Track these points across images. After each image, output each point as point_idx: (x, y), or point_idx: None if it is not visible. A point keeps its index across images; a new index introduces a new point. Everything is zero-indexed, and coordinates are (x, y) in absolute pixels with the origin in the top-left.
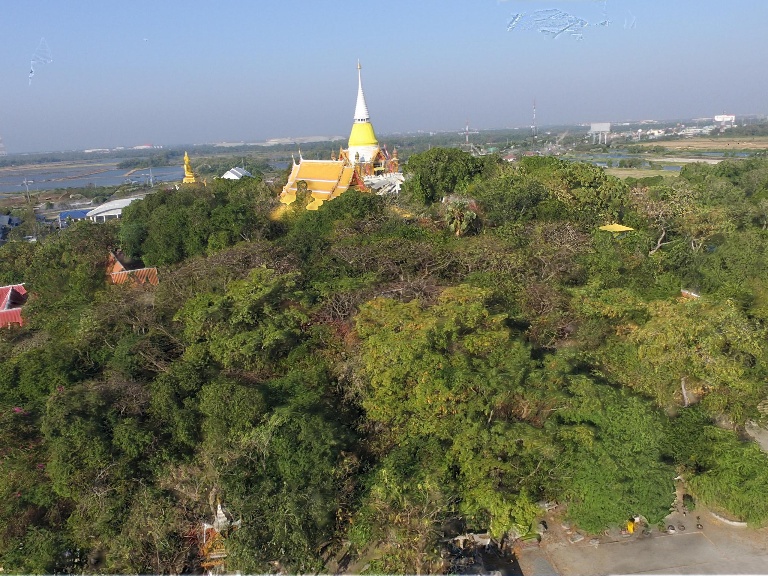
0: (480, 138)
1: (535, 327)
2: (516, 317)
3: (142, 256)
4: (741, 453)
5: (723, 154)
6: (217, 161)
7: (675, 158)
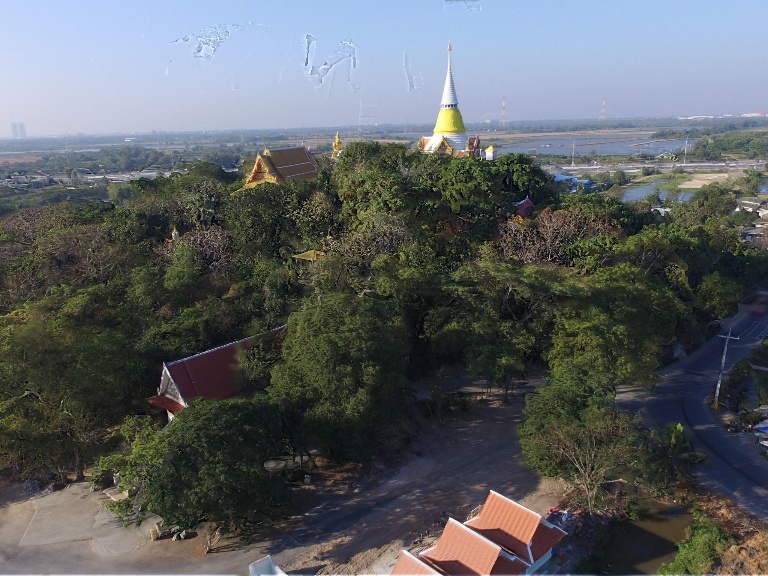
0: None
1: None
2: None
3: None
4: None
5: None
6: (725, 136)
7: None
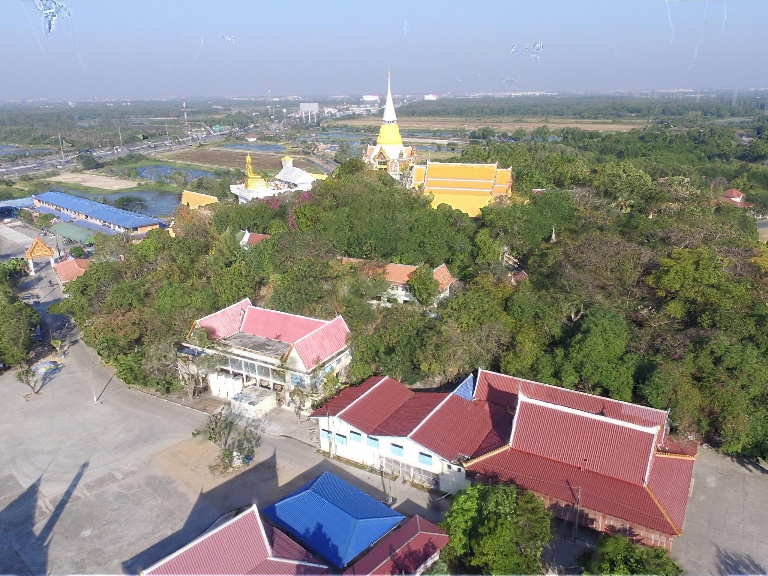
0: (201, 115)
1: None
2: None
3: None
4: None
5: (432, 134)
6: None
7: None
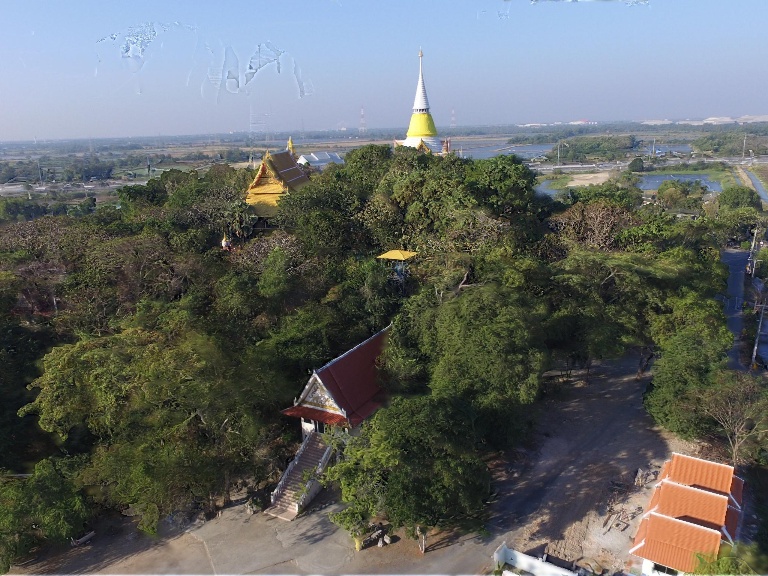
0: None
1: (58, 324)
2: (72, 312)
3: None
4: (3, 490)
5: None
6: (578, 141)
7: None
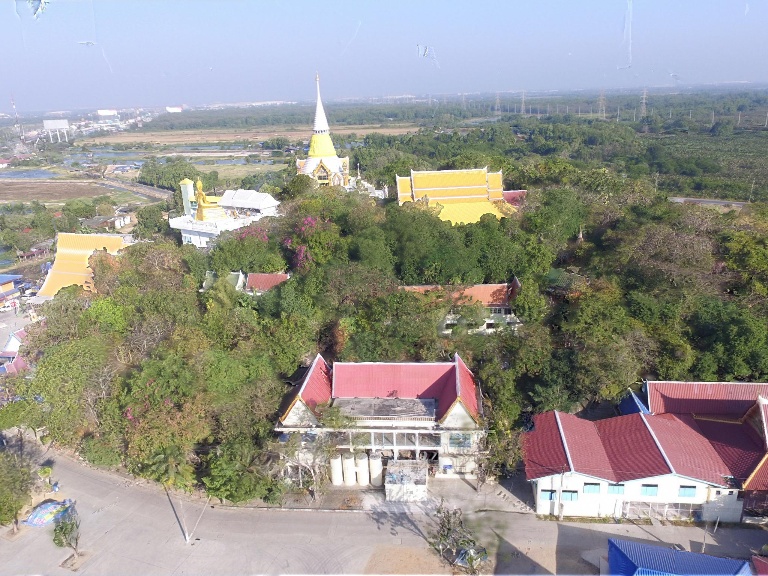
0: None
1: None
2: None
3: (454, 278)
4: None
5: (219, 147)
6: None
7: (178, 153)
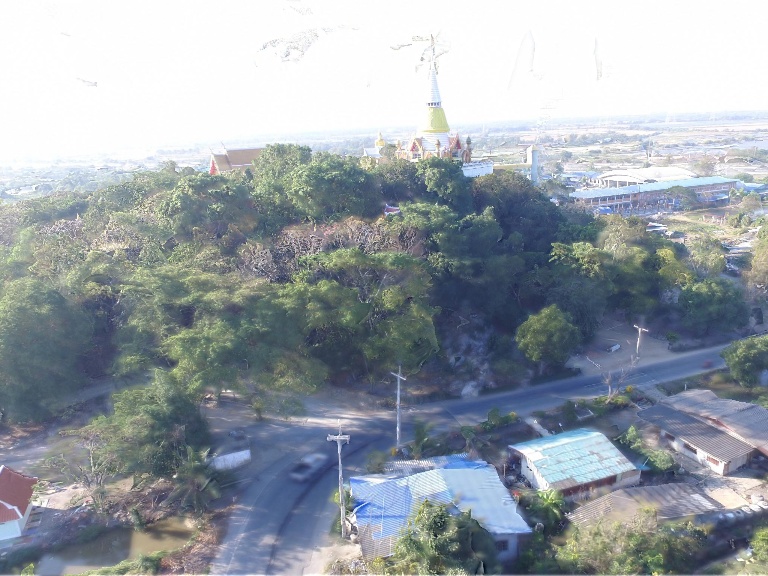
0: None
1: None
2: None
3: None
4: None
5: None
6: None
7: None
